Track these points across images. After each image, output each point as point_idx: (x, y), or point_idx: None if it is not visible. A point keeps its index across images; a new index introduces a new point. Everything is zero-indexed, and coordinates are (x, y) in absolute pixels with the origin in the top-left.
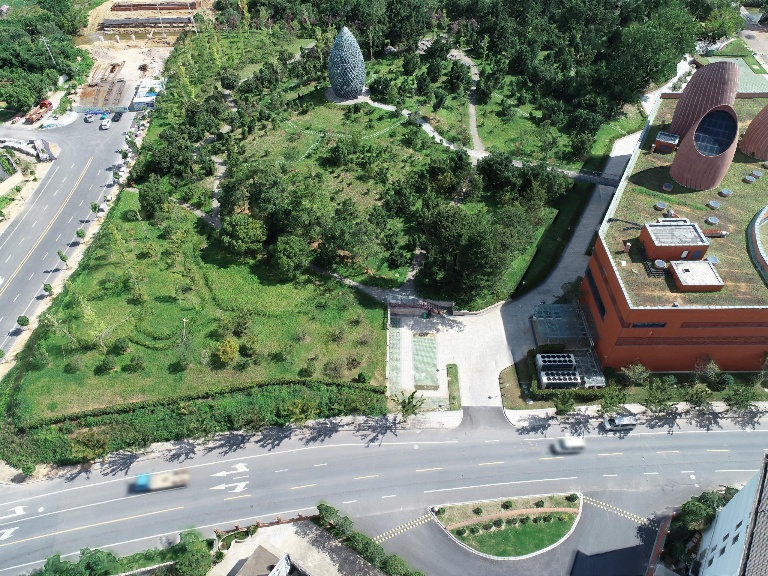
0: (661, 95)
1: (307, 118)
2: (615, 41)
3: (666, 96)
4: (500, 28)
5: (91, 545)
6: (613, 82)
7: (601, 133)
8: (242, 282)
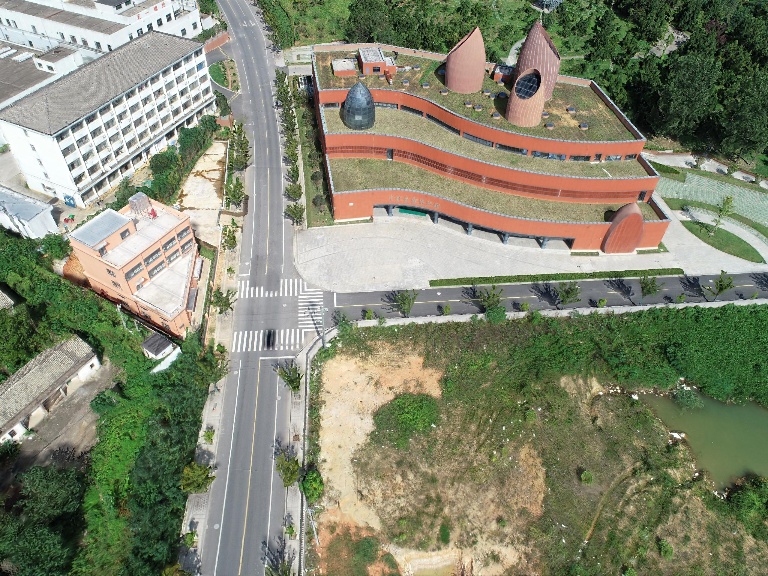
0: None
1: (510, 1)
2: None
3: None
4: (704, 41)
5: (222, 5)
6: None
7: None
8: (349, 2)
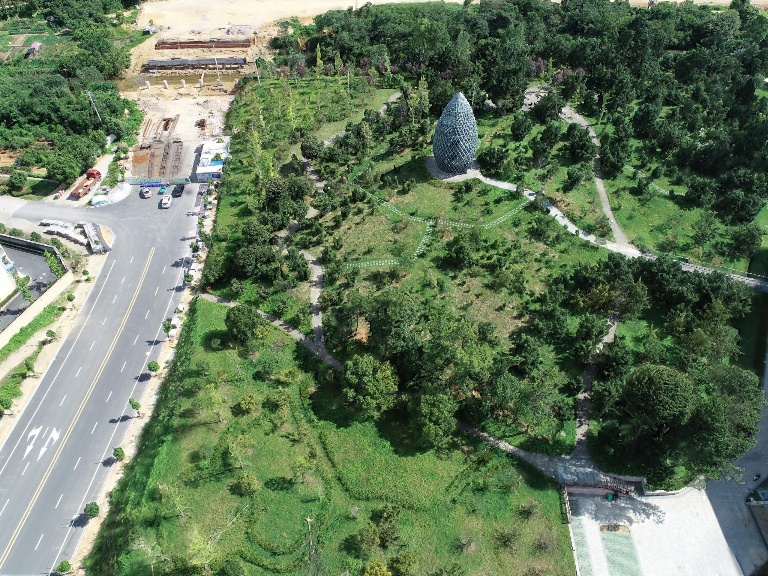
0: None
1: (409, 199)
2: (746, 95)
3: None
4: (618, 82)
5: None
6: (755, 148)
7: (757, 216)
8: (371, 450)
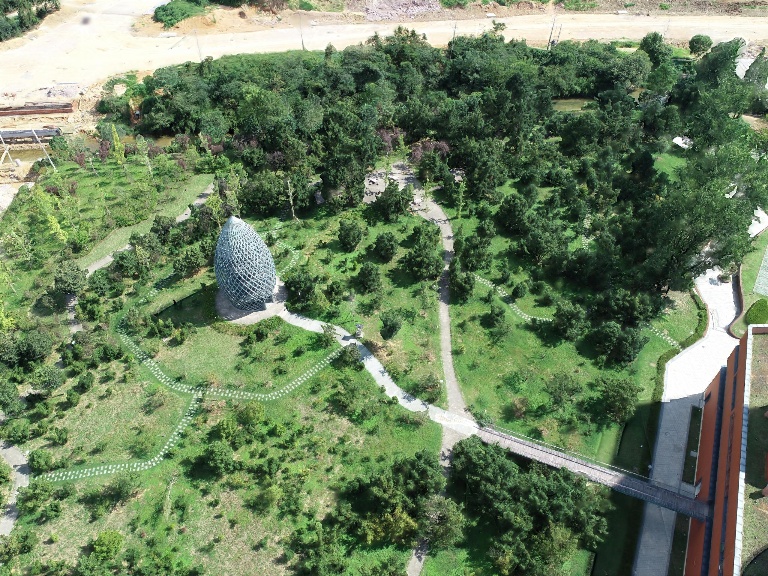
0: (751, 330)
1: (182, 353)
2: (643, 169)
3: (758, 330)
4: (482, 164)
5: None
6: (648, 244)
7: None
8: None
